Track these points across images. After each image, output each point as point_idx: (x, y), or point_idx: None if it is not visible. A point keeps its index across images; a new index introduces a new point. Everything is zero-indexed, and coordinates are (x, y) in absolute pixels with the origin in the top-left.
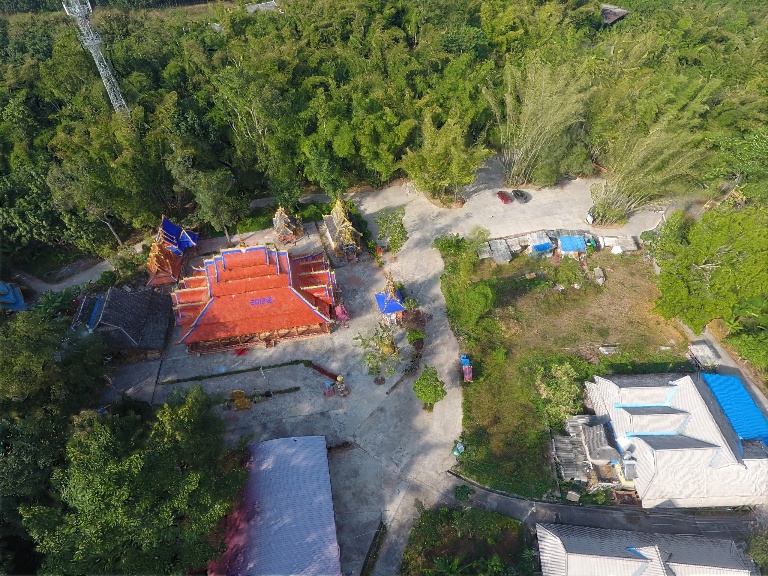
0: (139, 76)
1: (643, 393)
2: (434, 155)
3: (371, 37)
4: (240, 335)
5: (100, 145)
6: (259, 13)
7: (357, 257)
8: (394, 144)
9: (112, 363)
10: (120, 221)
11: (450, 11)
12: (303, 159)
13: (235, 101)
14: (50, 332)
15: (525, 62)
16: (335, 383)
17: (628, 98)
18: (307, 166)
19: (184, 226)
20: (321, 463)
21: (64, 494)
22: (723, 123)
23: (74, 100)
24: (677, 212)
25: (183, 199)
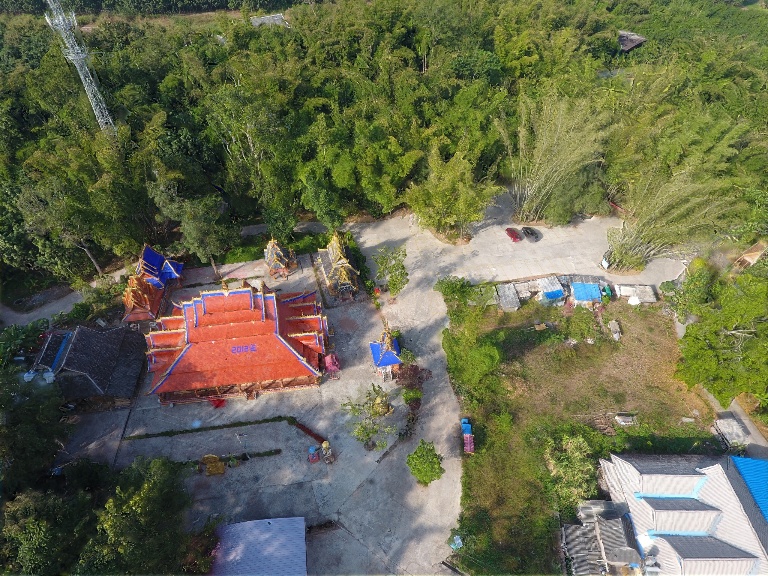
0: (132, 90)
1: (667, 482)
2: (440, 190)
3: (379, 57)
4: (218, 386)
5: (79, 167)
6: (264, 27)
7: (353, 297)
8: (398, 175)
9: (75, 411)
10: (99, 246)
11: (463, 33)
12: (300, 187)
13: (229, 123)
14: None
15: (540, 92)
16: (320, 448)
17: (650, 137)
18: (304, 193)
19: (169, 254)
20: (298, 553)
21: None
22: (751, 168)
23: (61, 113)
24: (703, 266)
25: (170, 223)
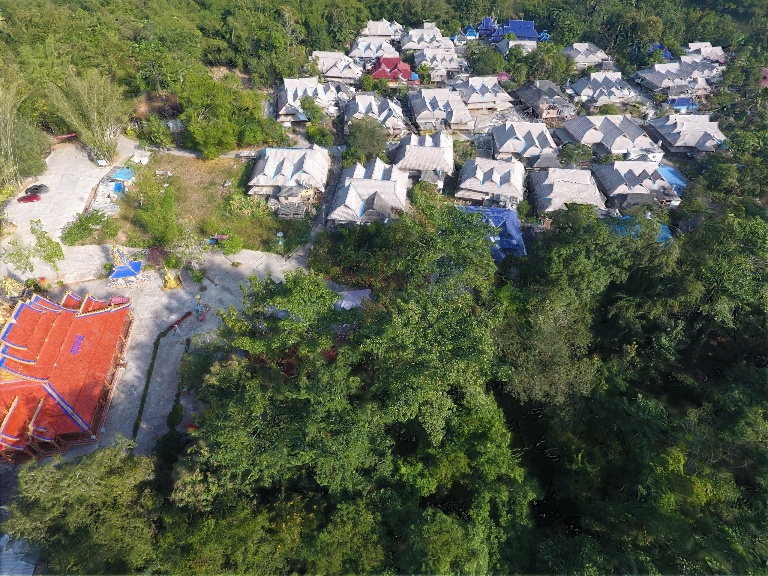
0: None
1: (268, 167)
2: None
3: None
4: None
5: None
6: None
7: None
8: None
9: None
10: None
11: None
12: None
13: None
14: None
15: None
16: None
17: None
18: None
19: None
20: None
21: (292, 341)
22: None
23: None
24: (148, 111)
25: None
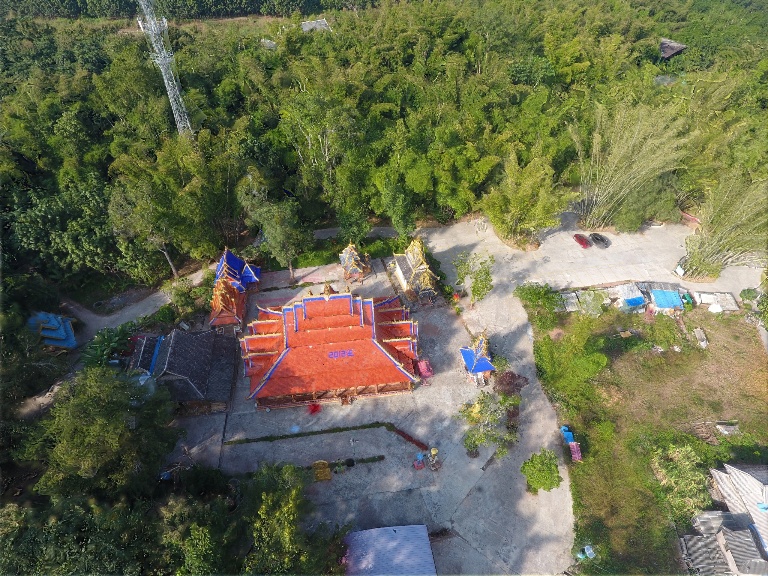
0: (198, 94)
1: None
2: (520, 196)
3: (433, 62)
4: (316, 391)
5: (167, 170)
6: (316, 32)
7: (432, 302)
8: (473, 181)
9: None
10: (177, 250)
11: (517, 40)
12: (373, 191)
13: (308, 128)
14: (120, 390)
15: (606, 98)
16: (426, 455)
17: (727, 144)
18: (374, 198)
19: (243, 257)
20: (426, 561)
21: None
22: None
23: (130, 116)
24: None
25: None
